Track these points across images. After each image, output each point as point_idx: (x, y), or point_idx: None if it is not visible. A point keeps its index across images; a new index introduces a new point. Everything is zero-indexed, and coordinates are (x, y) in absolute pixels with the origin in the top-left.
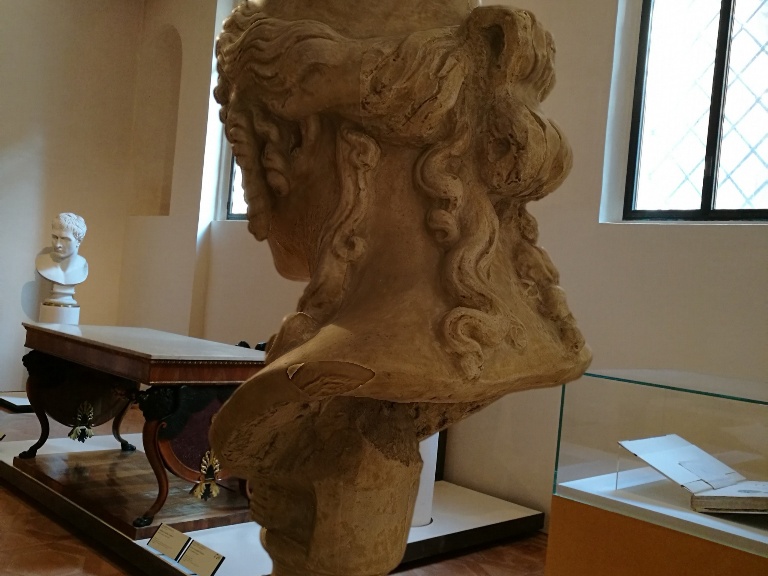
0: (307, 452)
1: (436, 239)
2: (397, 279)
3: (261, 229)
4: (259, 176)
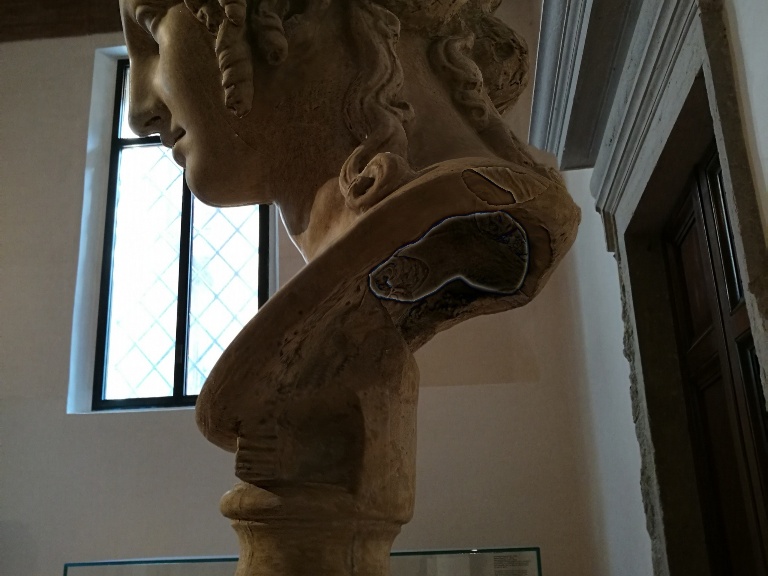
0: (337, 360)
1: (472, 117)
2: (464, 140)
3: (248, 99)
4: (245, 39)
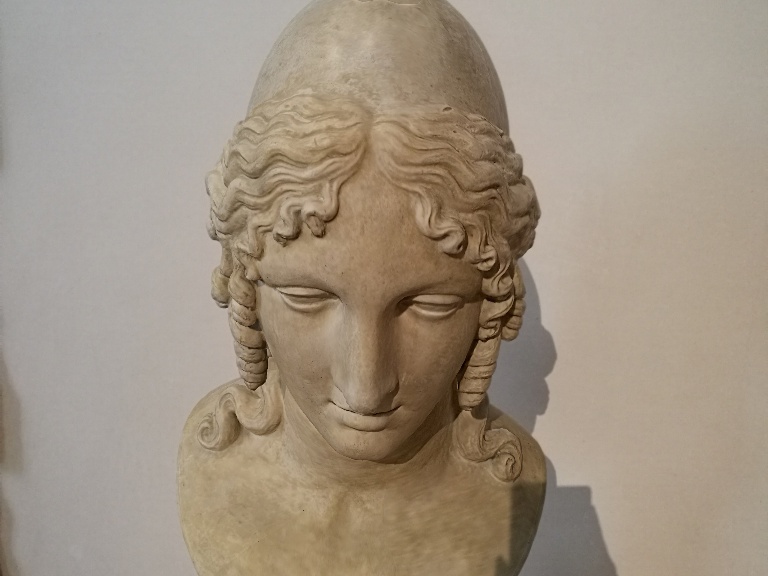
0: None
1: None
2: None
3: None
4: None
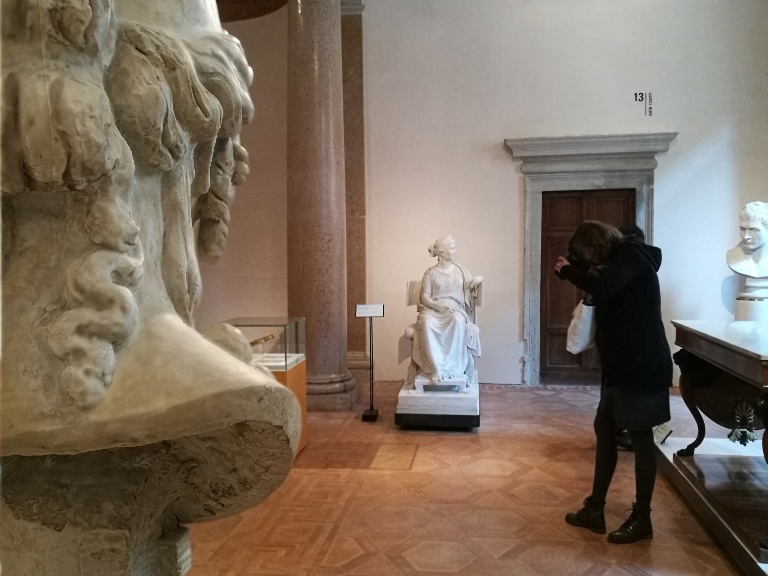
0: None
1: None
2: None
3: None
4: None
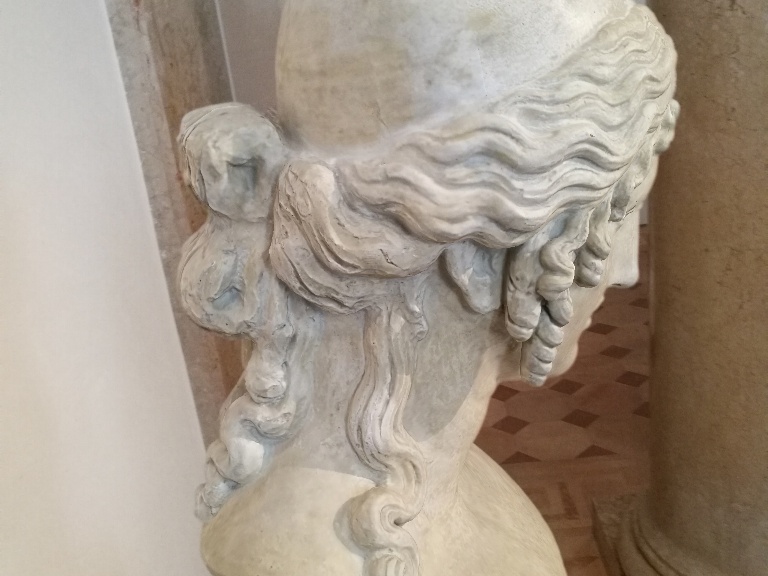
0: None
1: None
2: None
3: None
4: None
